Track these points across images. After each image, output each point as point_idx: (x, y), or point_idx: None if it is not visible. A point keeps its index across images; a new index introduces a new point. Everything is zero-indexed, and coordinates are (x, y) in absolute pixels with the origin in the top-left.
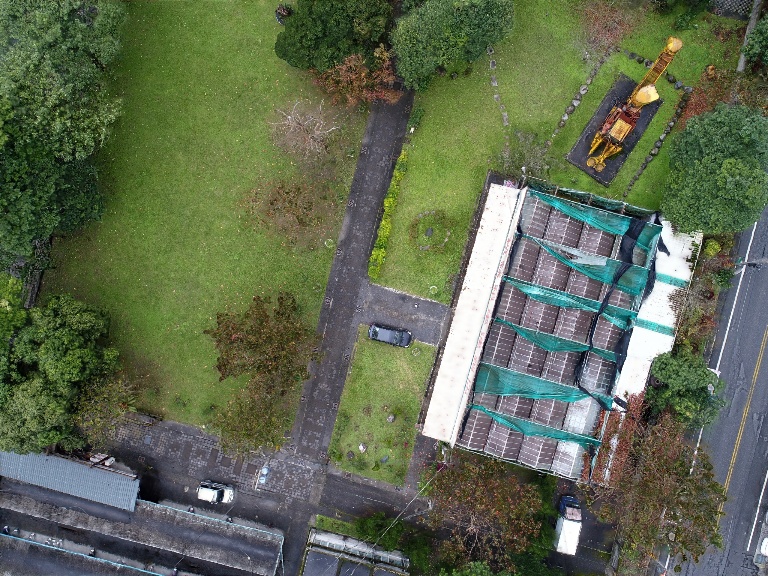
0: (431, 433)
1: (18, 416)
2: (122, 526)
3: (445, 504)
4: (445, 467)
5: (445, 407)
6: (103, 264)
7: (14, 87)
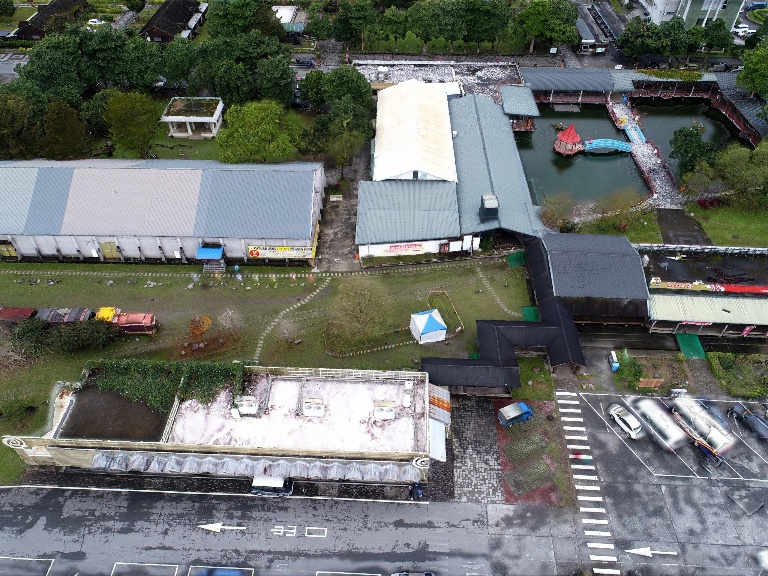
0: None
1: (563, 3)
2: (592, 24)
3: None
4: None
5: None
6: (501, 45)
7: None
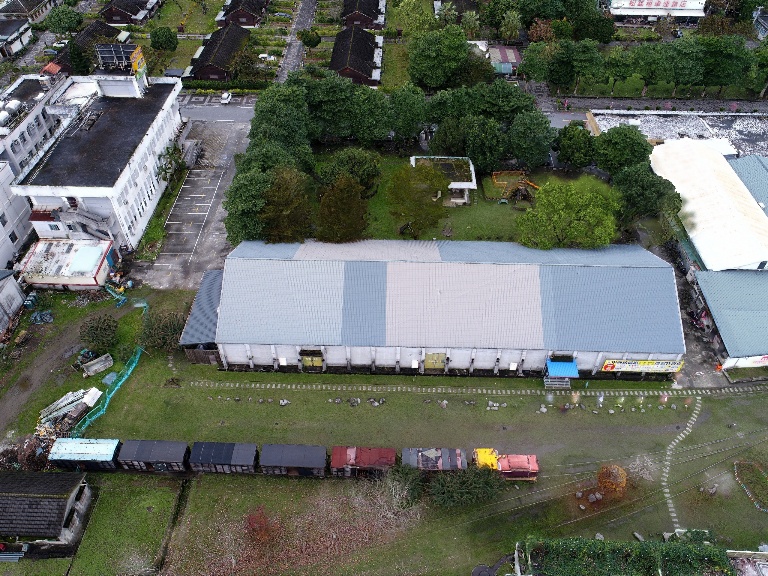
0: (703, 14)
1: None
2: None
3: (723, 5)
4: (712, 4)
5: (692, 13)
6: None
7: (691, 39)
